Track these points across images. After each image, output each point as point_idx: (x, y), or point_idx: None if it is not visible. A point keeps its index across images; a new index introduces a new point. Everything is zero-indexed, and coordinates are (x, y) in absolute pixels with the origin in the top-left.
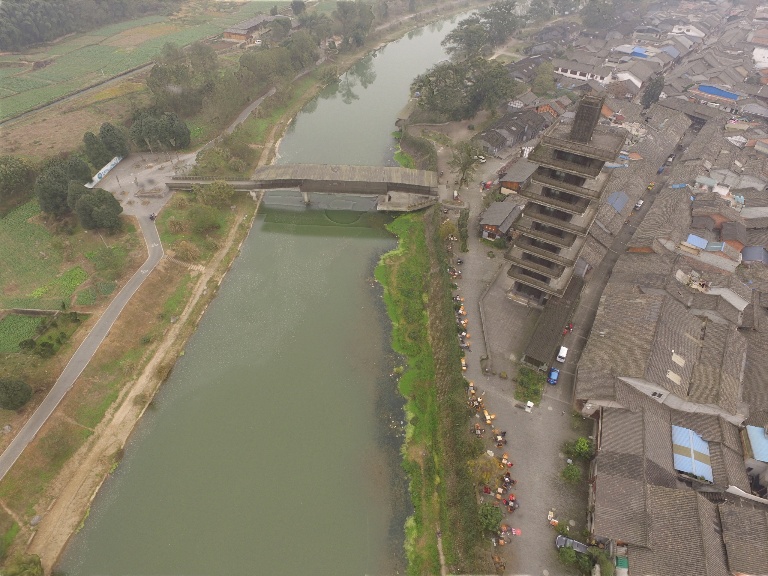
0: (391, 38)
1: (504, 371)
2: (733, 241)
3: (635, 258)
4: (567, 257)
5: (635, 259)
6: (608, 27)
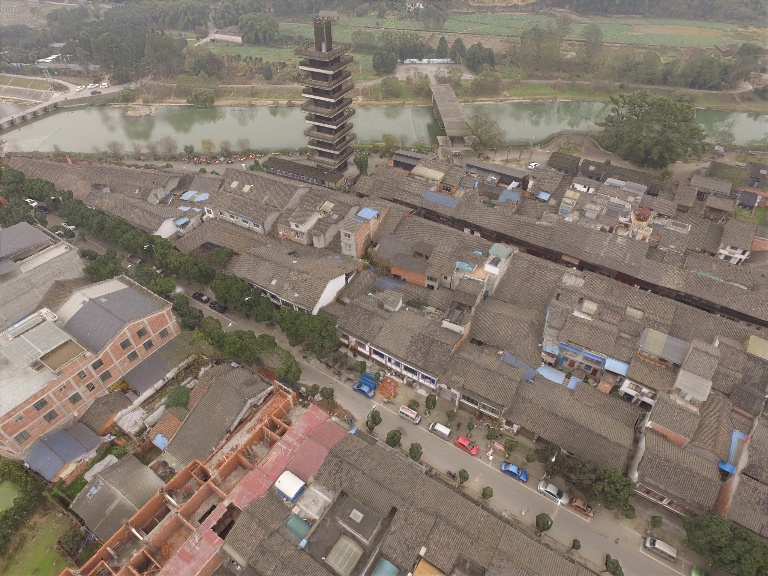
0: None
1: None
2: None
3: (360, 200)
4: None
5: (358, 200)
6: None
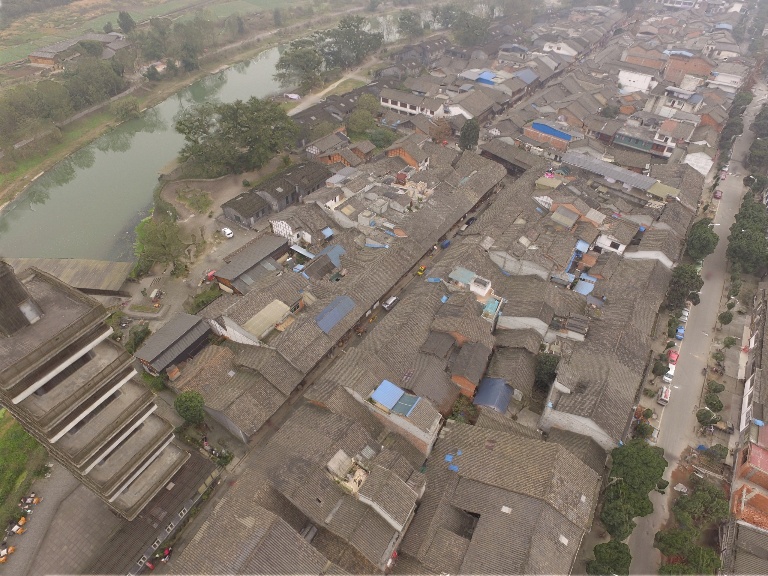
0: (239, 58)
1: None
2: (461, 377)
3: (307, 418)
4: (112, 470)
5: (305, 420)
6: (482, 43)
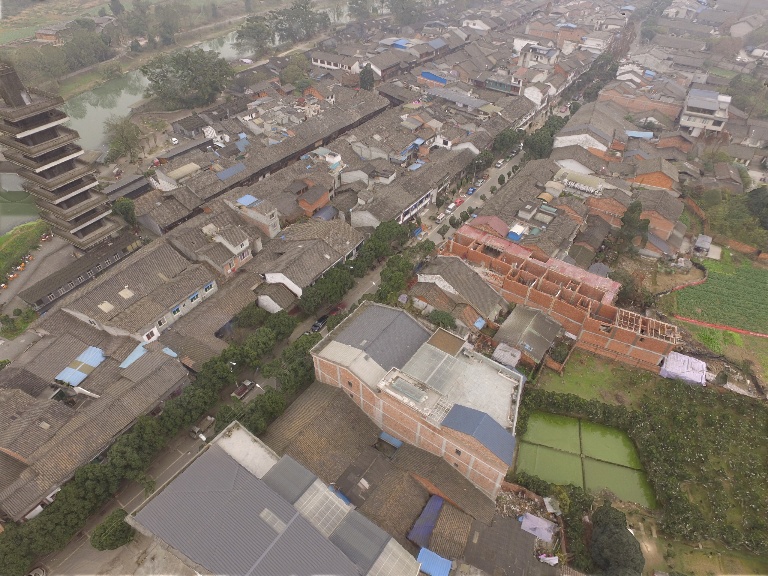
0: (211, 37)
1: (10, 313)
2: (303, 201)
3: (198, 217)
4: None
5: (197, 218)
6: None
